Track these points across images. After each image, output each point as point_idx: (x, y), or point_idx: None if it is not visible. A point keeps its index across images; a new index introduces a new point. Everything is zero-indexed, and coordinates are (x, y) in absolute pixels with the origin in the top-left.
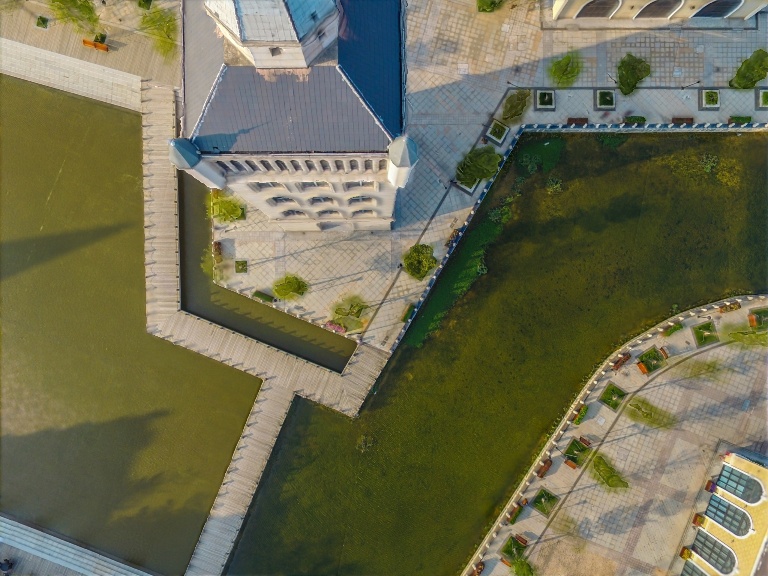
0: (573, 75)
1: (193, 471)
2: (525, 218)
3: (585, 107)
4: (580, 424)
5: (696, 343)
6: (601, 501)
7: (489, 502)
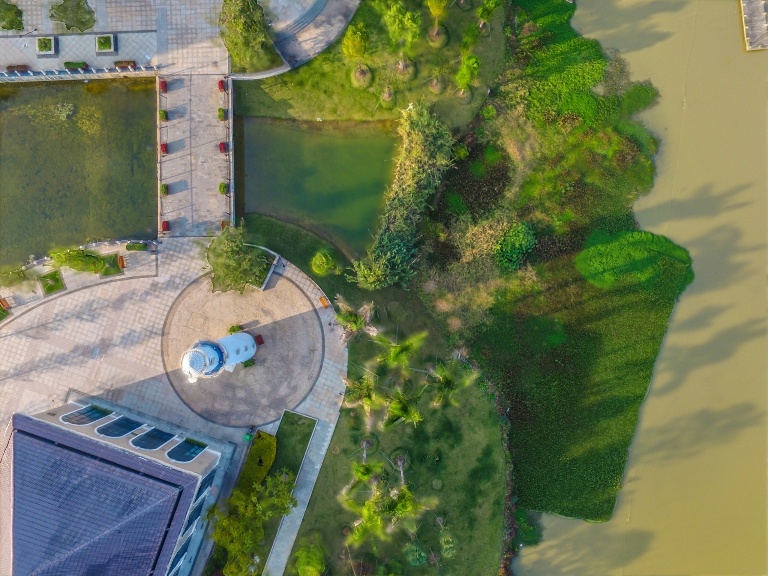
0: None
1: None
2: None
3: None
4: None
5: (43, 292)
6: None
7: None
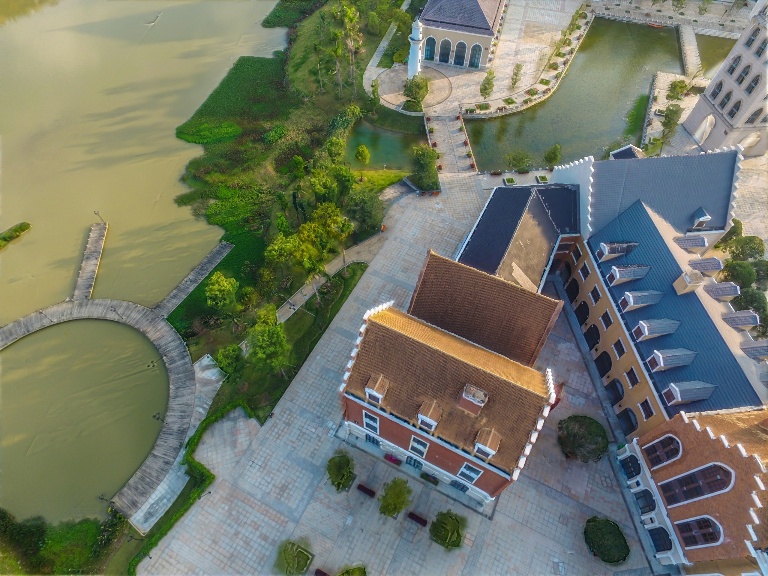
0: None
1: (712, 59)
2: (614, 138)
3: None
4: None
5: None
6: None
7: (581, 57)
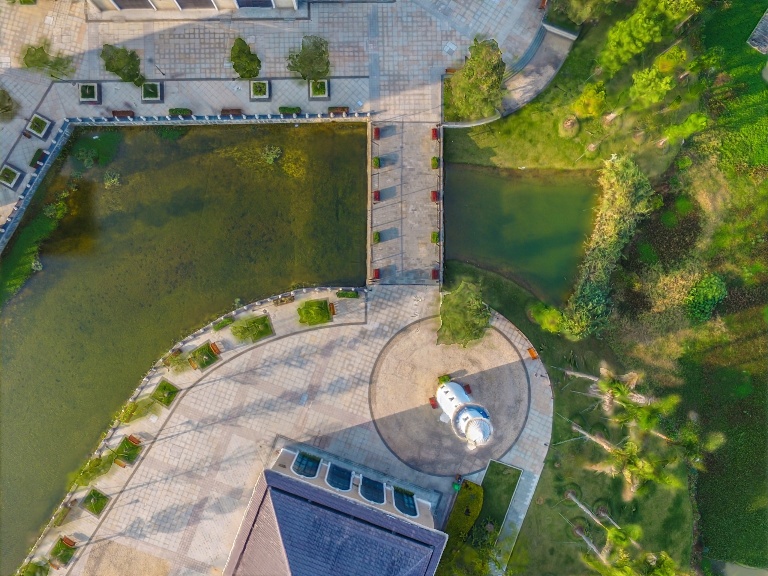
0: (65, 66)
1: None
2: (83, 213)
3: (133, 100)
4: (131, 422)
5: (252, 337)
6: (154, 500)
7: (46, 503)
